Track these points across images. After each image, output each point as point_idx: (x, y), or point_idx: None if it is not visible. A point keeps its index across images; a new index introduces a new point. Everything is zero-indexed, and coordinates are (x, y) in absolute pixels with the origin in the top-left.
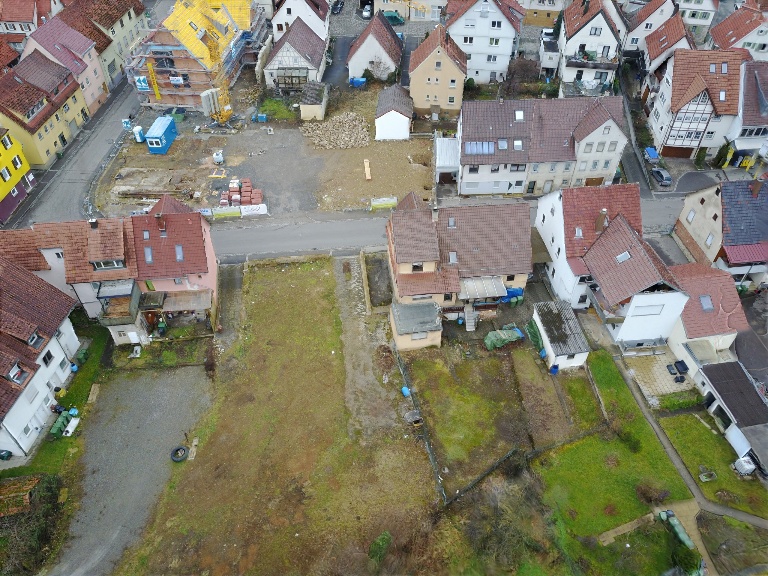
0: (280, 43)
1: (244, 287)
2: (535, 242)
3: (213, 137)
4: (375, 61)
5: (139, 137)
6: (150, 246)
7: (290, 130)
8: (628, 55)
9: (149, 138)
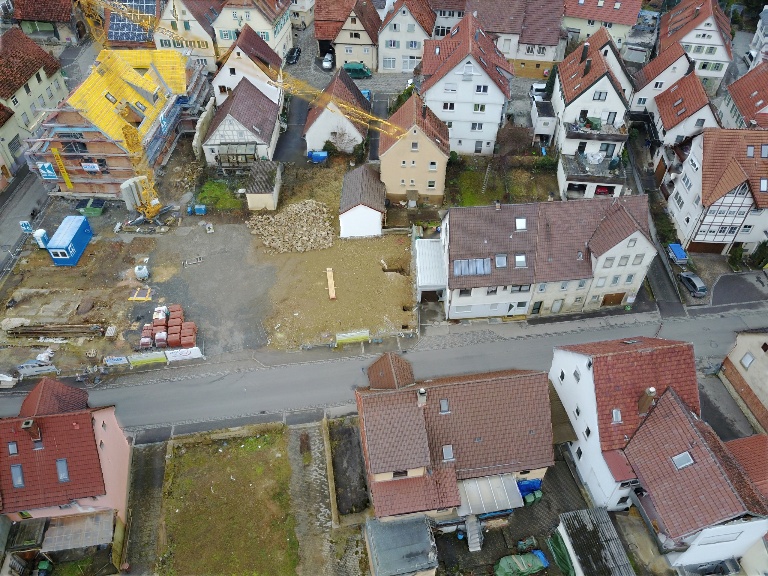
0: (222, 111)
1: (165, 485)
2: (552, 406)
3: (138, 238)
4: (338, 132)
5: (42, 243)
6: (19, 463)
7: (235, 226)
8: (635, 118)
9: (52, 249)
